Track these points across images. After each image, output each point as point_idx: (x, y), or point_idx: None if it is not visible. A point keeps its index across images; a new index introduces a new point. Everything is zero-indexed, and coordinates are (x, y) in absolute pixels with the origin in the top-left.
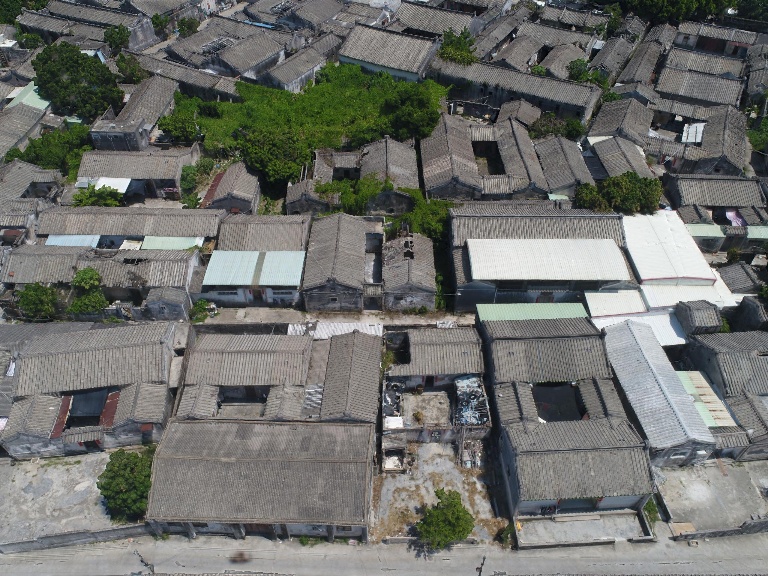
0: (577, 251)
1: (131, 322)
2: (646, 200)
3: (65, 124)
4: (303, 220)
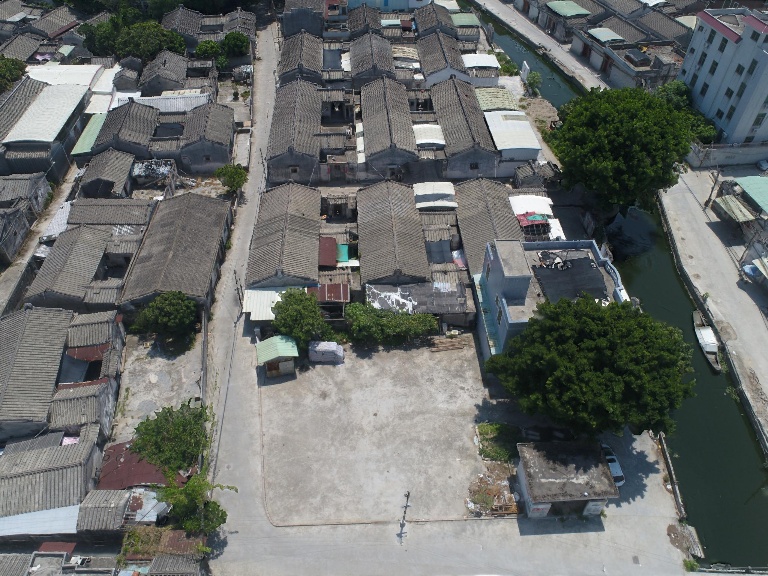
0: (51, 98)
1: None
2: (17, 65)
3: None
4: None
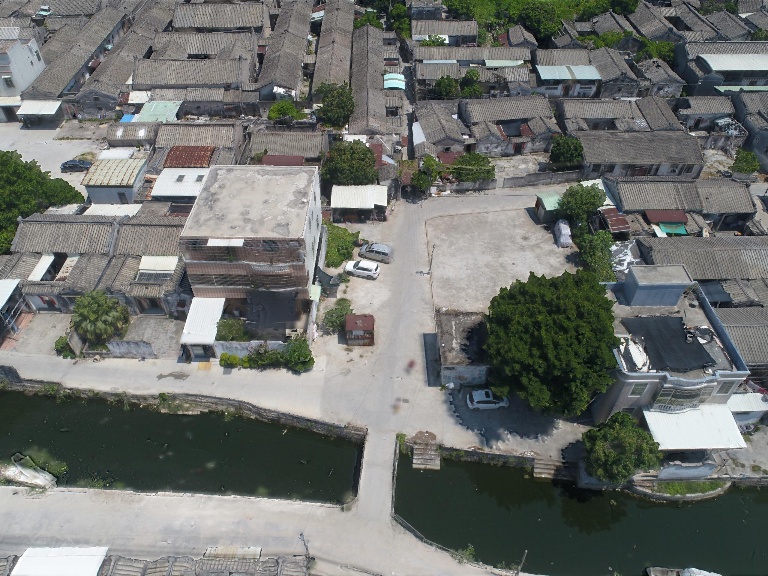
0: None
1: None
2: None
3: (365, 13)
4: None
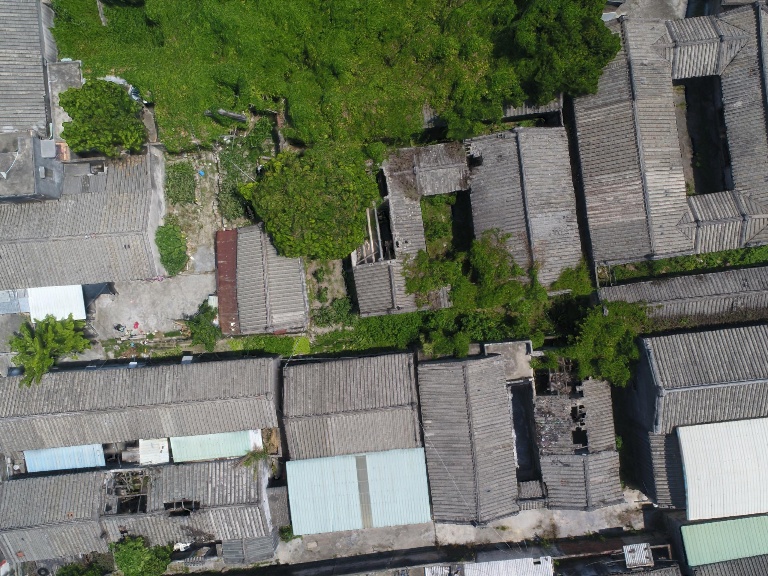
0: None
1: (206, 548)
2: None
3: None
4: (414, 409)
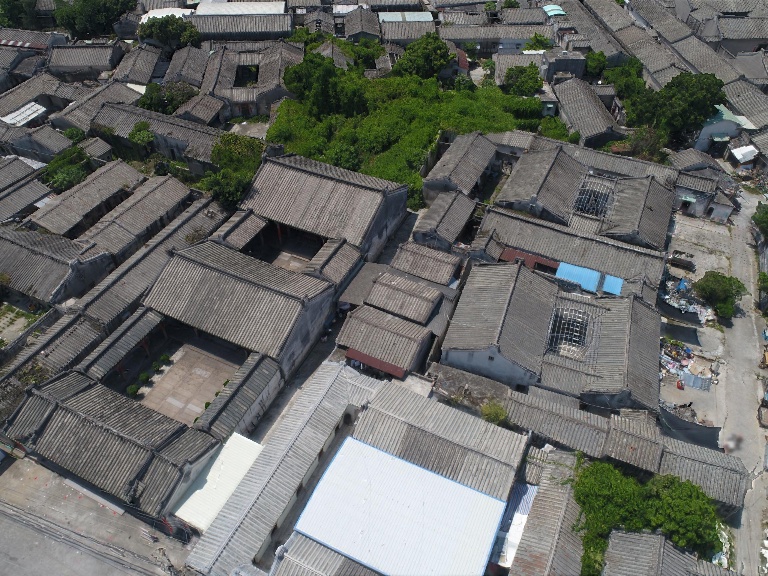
0: (222, 8)
1: None
2: None
3: None
4: None
